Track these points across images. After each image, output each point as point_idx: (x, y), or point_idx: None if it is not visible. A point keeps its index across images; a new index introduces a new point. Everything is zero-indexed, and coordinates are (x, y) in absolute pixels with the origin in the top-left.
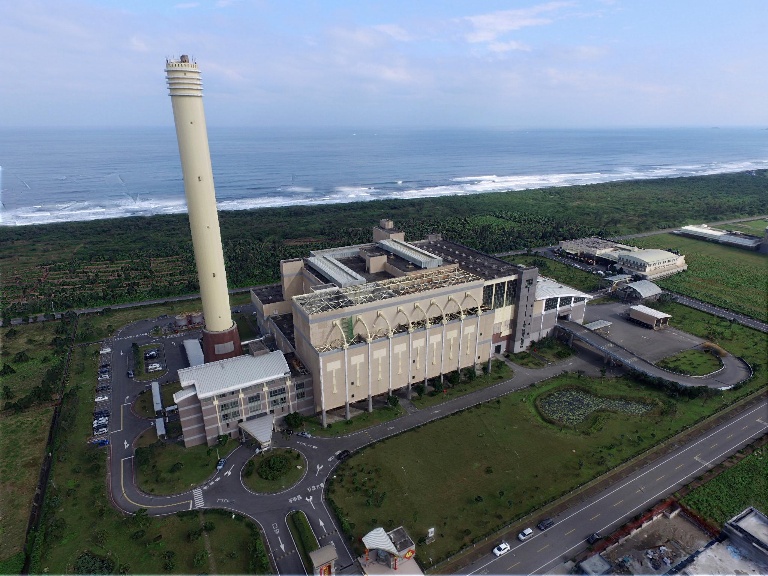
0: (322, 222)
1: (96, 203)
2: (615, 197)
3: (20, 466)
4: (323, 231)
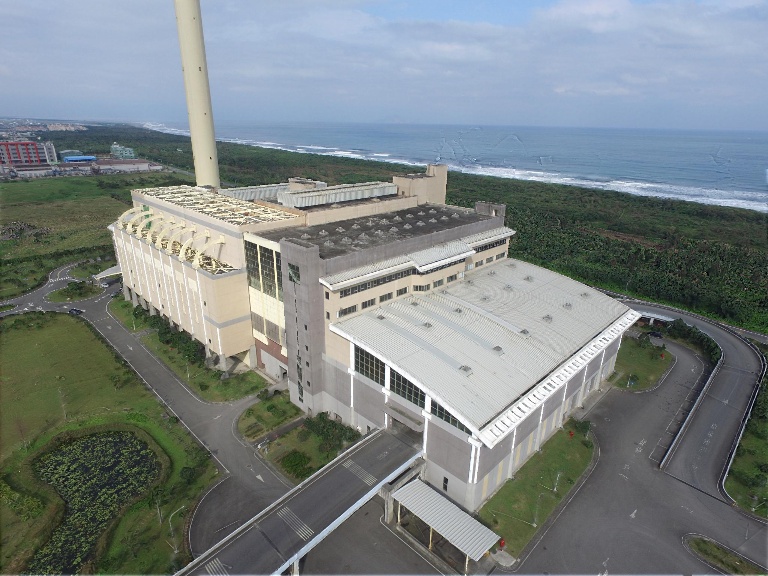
0: None
1: (510, 162)
2: None
3: None
4: (667, 233)
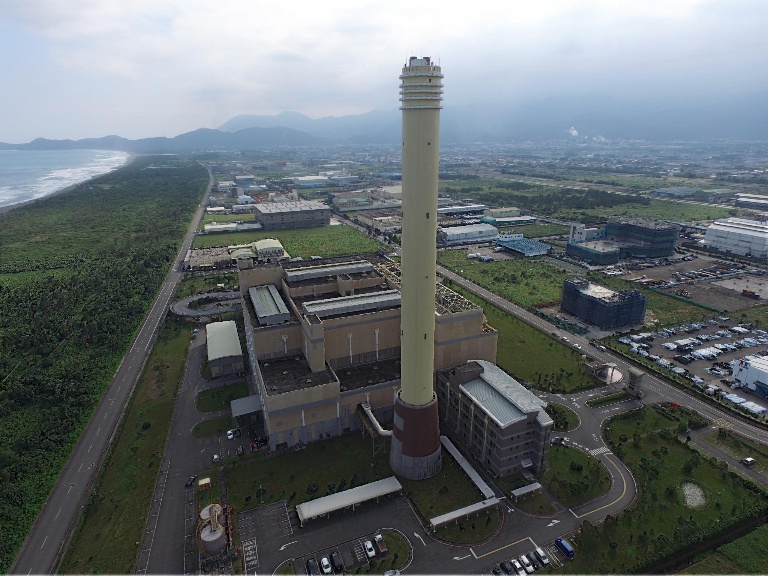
0: None
1: None
2: (58, 224)
3: None
4: None
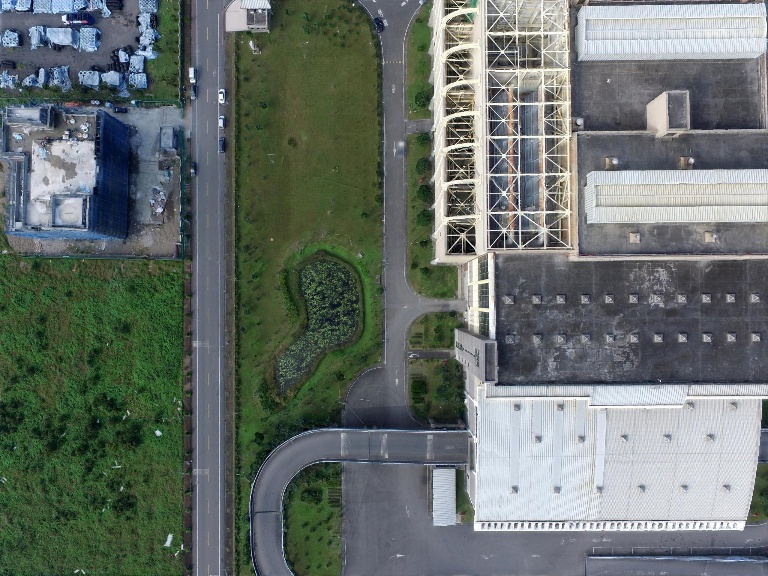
0: None
1: None
2: None
3: None
4: None
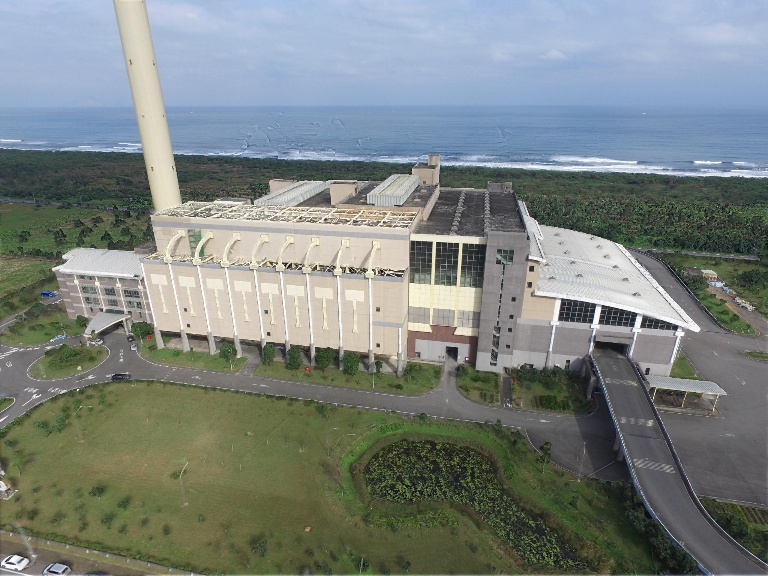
0: (515, 185)
1: (329, 145)
2: None
3: (4, 290)
4: None
